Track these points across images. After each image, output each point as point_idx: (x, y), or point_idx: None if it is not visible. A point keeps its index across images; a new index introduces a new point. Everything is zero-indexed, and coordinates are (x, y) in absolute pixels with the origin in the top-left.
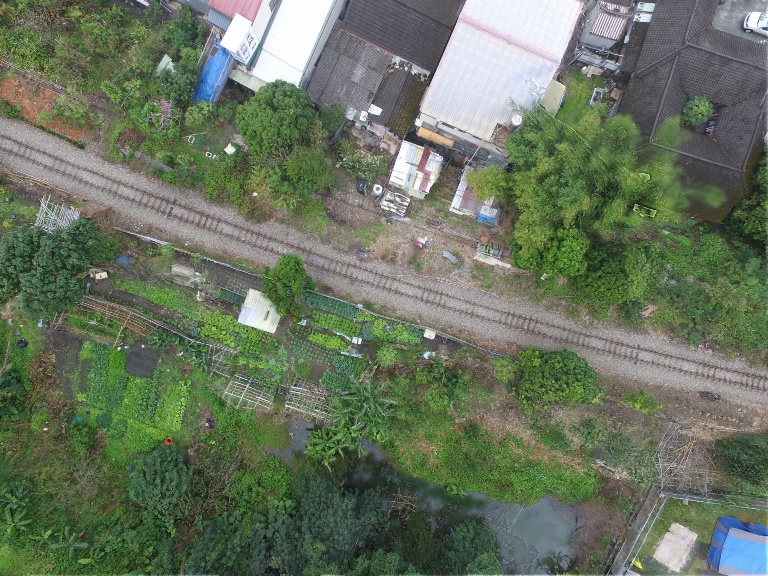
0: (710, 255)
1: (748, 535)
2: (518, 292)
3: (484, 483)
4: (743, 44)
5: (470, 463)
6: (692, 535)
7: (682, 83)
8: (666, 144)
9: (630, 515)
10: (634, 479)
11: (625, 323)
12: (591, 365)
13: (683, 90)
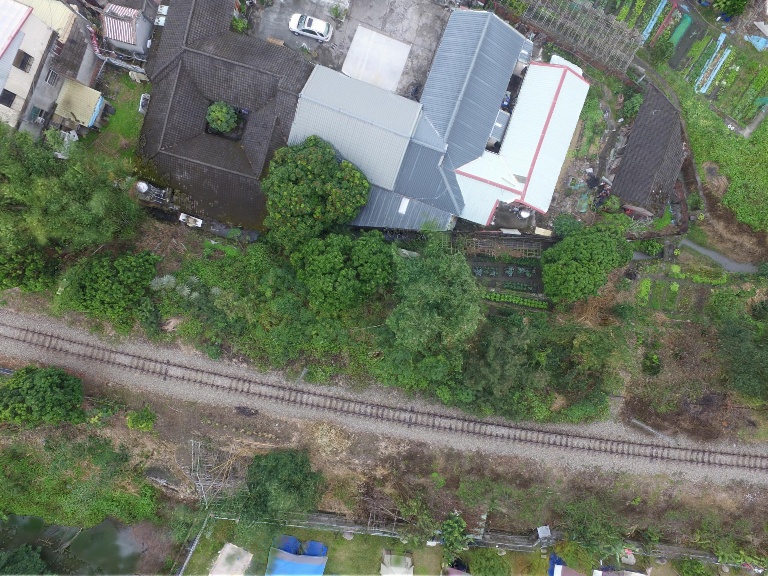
0: (251, 265)
1: (285, 555)
2: (35, 308)
3: (33, 506)
4: (258, 47)
5: (6, 487)
6: (248, 555)
7: (199, 88)
8: (179, 152)
9: (185, 536)
10: (197, 498)
11: (147, 338)
12: (119, 382)
13: (203, 95)
